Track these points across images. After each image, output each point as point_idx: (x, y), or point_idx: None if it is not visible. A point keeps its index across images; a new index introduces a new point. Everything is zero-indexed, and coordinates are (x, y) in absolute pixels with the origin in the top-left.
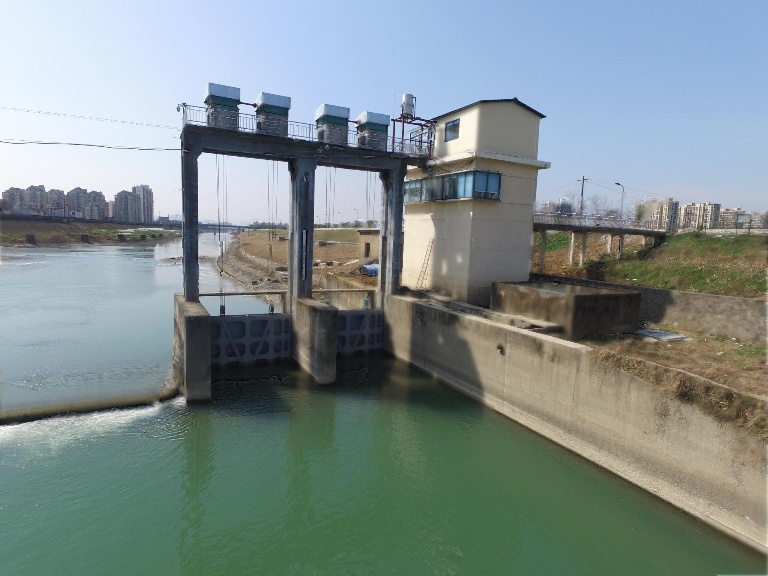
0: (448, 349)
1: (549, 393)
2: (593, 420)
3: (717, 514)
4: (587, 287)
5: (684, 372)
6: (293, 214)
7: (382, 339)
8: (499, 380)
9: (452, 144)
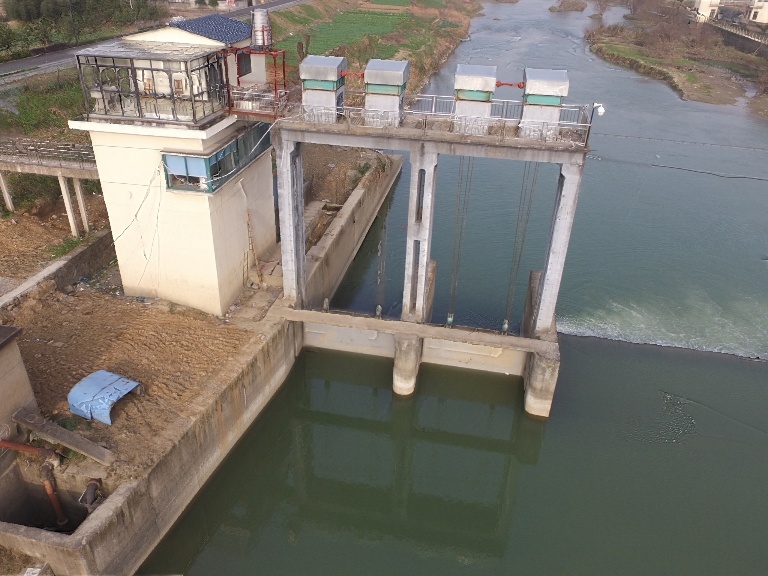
0: None
1: None
2: None
3: None
4: None
5: None
6: (430, 216)
7: None
8: None
9: (248, 80)
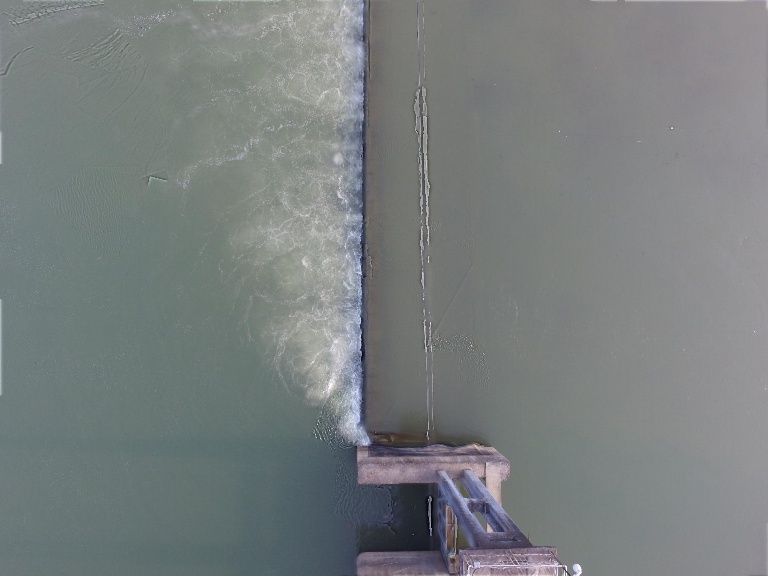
0: None
1: None
2: None
3: None
4: None
5: None
6: None
7: None
8: None
9: None
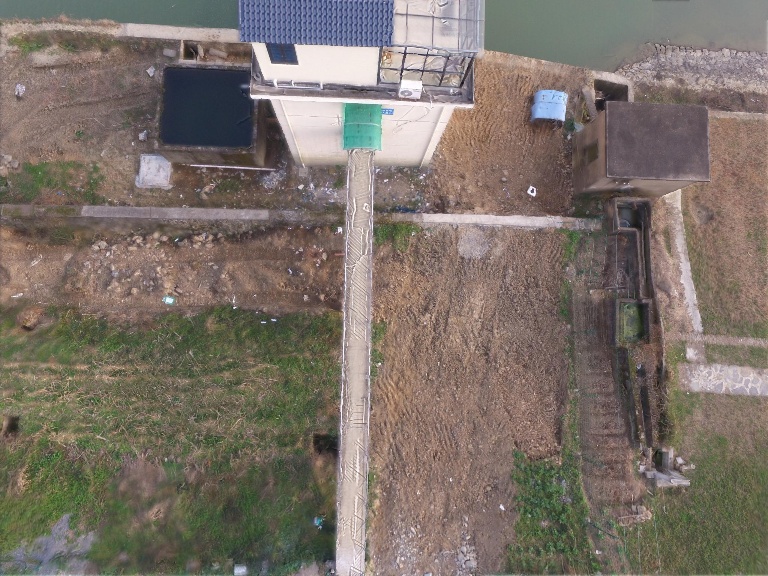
0: None
1: None
2: None
3: None
4: (209, 147)
5: (63, 27)
6: None
7: None
8: None
9: None
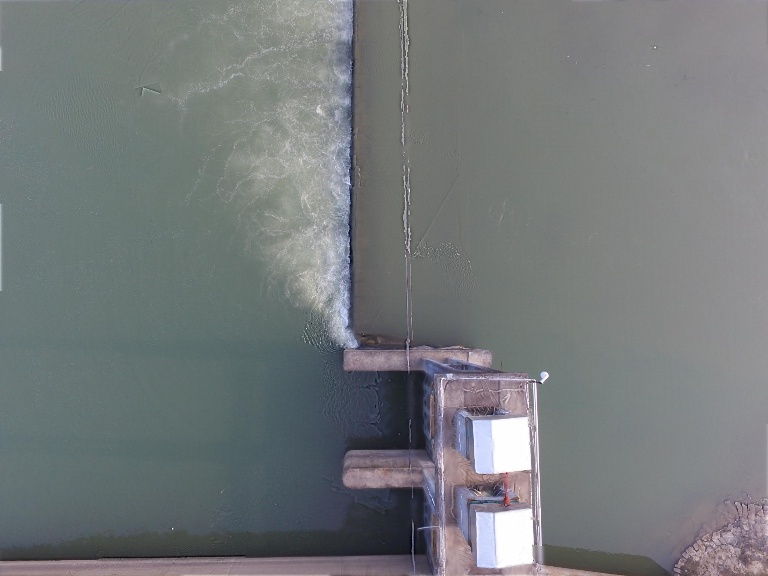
0: (303, 572)
1: (185, 573)
2: (151, 571)
3: (90, 561)
4: None
5: None
6: None
7: (428, 559)
8: (236, 569)
9: None
